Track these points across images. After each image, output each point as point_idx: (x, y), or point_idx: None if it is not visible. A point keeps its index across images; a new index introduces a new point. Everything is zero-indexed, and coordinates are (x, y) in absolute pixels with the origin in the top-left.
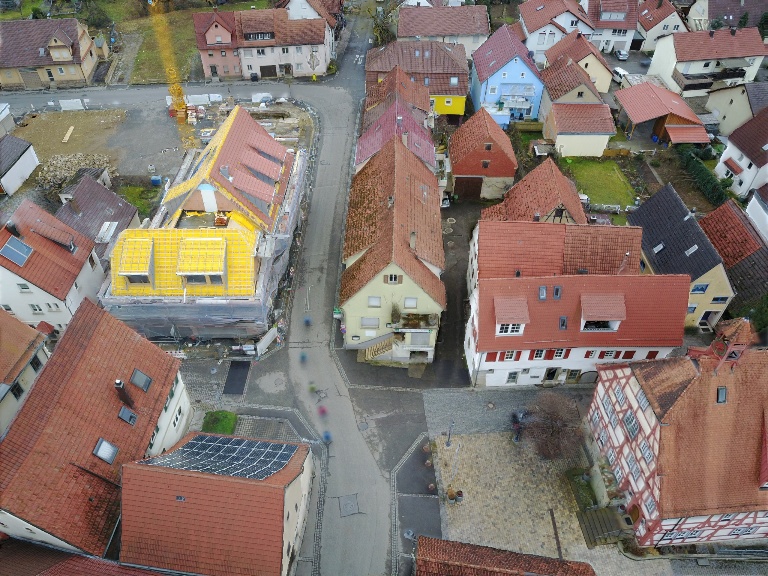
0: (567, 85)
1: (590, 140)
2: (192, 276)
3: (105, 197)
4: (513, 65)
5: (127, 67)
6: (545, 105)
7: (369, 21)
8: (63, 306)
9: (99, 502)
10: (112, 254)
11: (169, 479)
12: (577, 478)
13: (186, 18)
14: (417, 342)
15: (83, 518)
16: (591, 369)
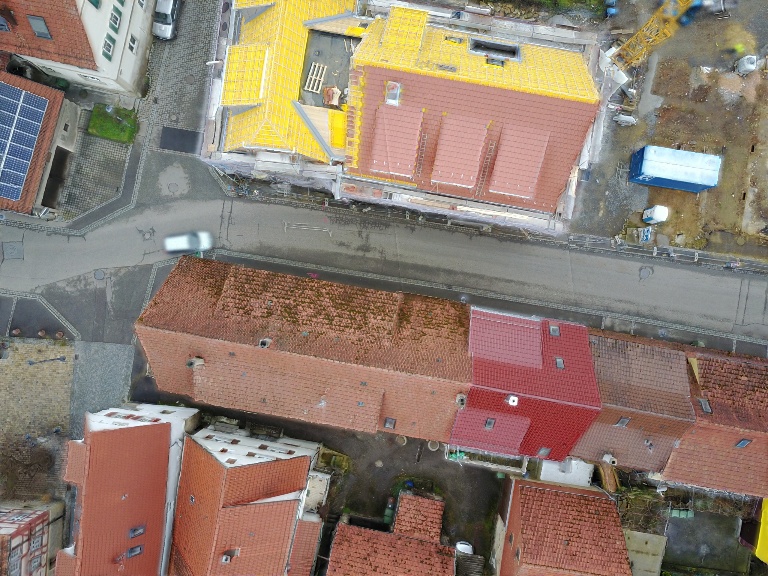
0: None
1: None
2: None
3: None
4: None
5: None
6: None
7: None
8: None
9: None
10: None
11: None
12: (7, 476)
13: None
14: None
15: None
16: None
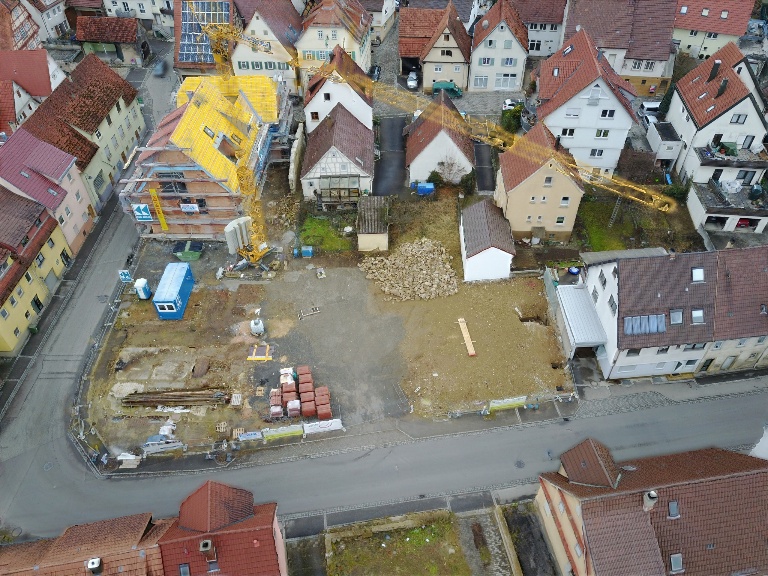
0: None
1: None
2: None
3: None
4: None
5: None
6: None
7: None
8: None
9: None
10: None
11: None
12: None
13: None
14: None
15: None
16: None
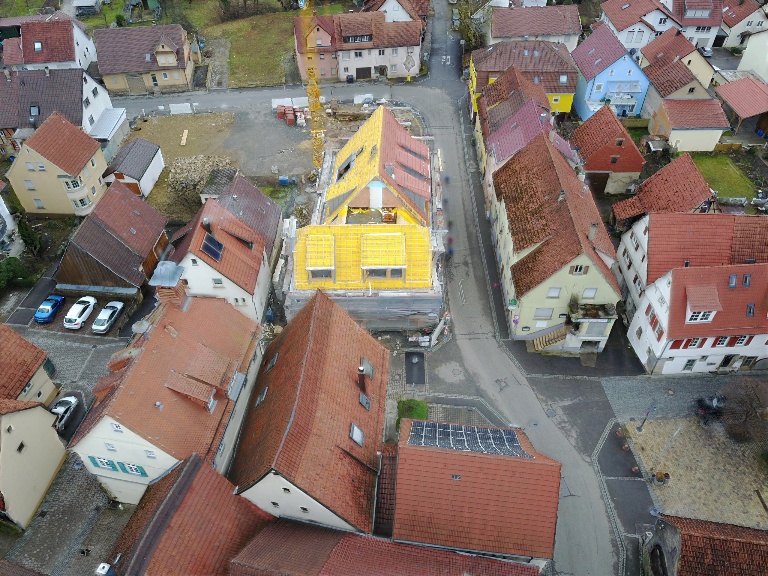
0: (677, 81)
1: (703, 135)
2: (375, 270)
3: (256, 196)
4: (621, 63)
5: (223, 71)
6: (652, 101)
7: (446, 23)
8: (250, 300)
9: (359, 483)
10: (295, 250)
11: (446, 459)
12: None
13: (267, 23)
14: (592, 332)
15: (351, 498)
16: (767, 356)
